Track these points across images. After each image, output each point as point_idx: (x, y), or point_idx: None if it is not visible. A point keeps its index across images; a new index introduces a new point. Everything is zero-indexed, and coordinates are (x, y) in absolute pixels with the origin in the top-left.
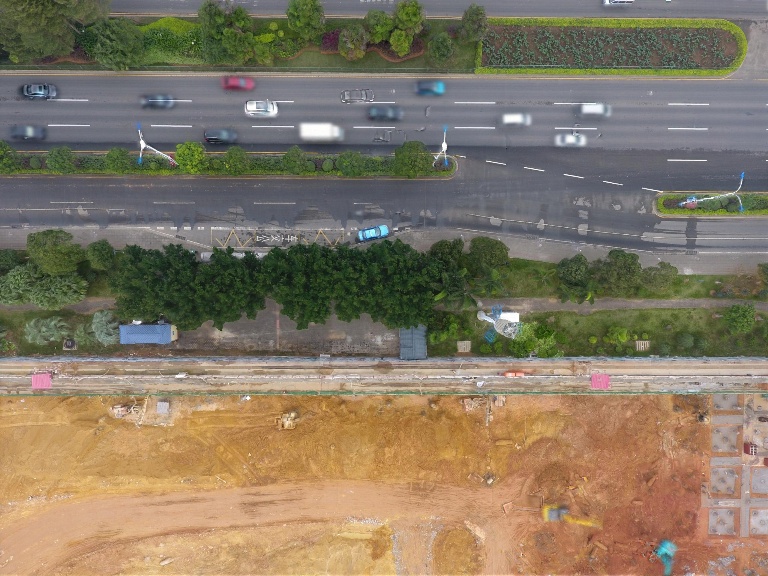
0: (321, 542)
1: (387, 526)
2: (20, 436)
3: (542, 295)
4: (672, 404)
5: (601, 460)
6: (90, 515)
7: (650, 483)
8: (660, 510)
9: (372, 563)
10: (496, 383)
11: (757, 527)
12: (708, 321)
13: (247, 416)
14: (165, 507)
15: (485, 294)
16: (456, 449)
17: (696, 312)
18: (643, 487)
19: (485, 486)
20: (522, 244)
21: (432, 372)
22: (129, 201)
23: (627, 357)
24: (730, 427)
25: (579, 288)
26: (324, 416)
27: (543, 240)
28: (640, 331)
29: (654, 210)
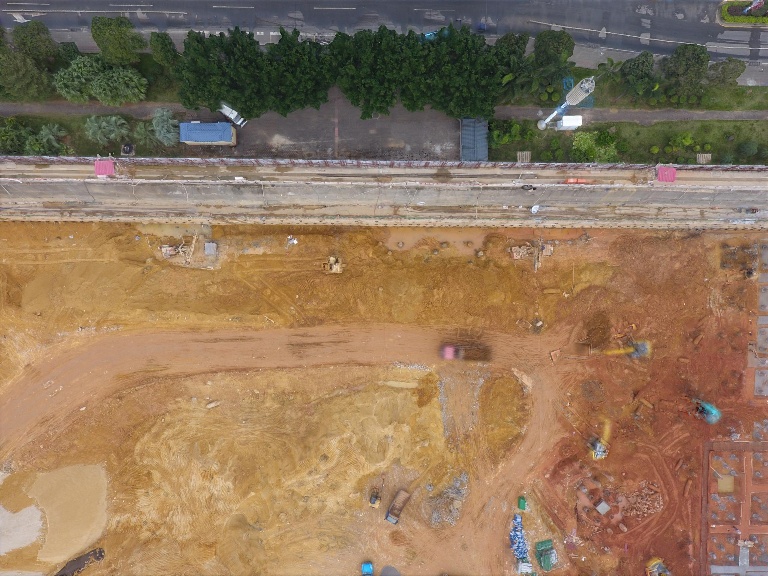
0: (367, 390)
1: (434, 372)
2: (69, 271)
3: (603, 105)
4: (719, 261)
5: (651, 306)
6: (139, 348)
7: (696, 341)
8: (706, 369)
9: (418, 410)
10: (551, 210)
11: None
12: None
13: (294, 260)
14: (213, 344)
15: (546, 100)
16: (505, 293)
17: (759, 124)
18: (689, 345)
19: (533, 333)
20: (583, 53)
21: (491, 182)
22: (188, 5)
23: (688, 169)
24: None
25: (647, 79)
26: (371, 263)
27: (605, 49)
28: (702, 143)
29: (717, 19)
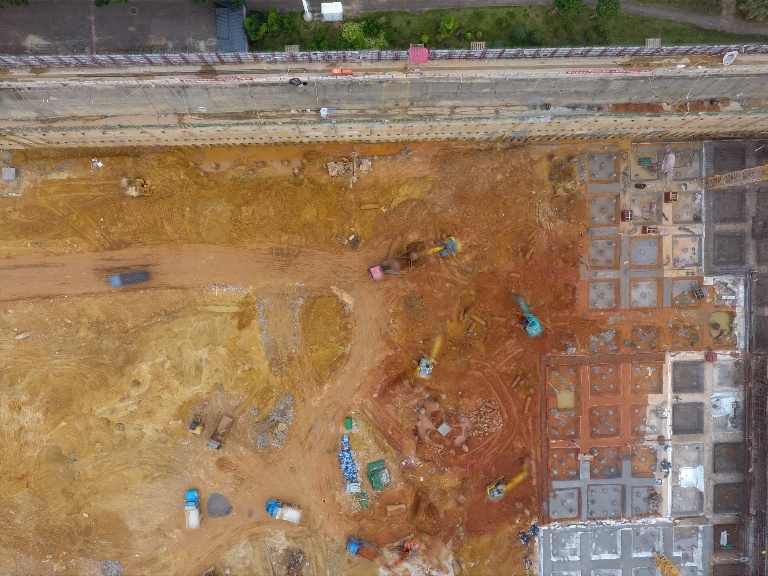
0: (185, 315)
1: (251, 294)
2: None
3: None
4: (547, 174)
5: (467, 216)
6: None
7: (527, 255)
8: (539, 284)
9: (238, 333)
10: (341, 113)
11: (638, 300)
12: (545, 19)
13: (100, 183)
14: (12, 271)
15: None
16: (317, 208)
17: (532, 10)
18: (521, 260)
19: (350, 249)
20: None
21: None
22: None
23: (462, 58)
24: (608, 198)
25: None
26: (182, 184)
27: None
28: (475, 31)
29: None
